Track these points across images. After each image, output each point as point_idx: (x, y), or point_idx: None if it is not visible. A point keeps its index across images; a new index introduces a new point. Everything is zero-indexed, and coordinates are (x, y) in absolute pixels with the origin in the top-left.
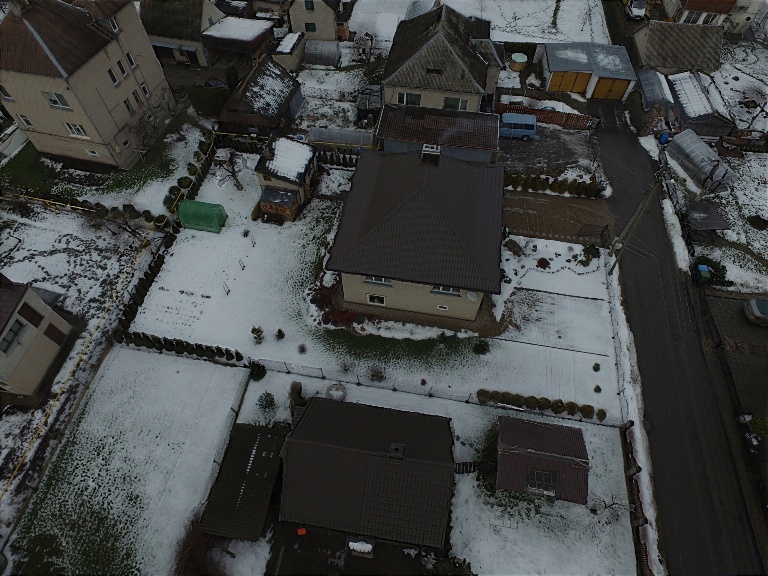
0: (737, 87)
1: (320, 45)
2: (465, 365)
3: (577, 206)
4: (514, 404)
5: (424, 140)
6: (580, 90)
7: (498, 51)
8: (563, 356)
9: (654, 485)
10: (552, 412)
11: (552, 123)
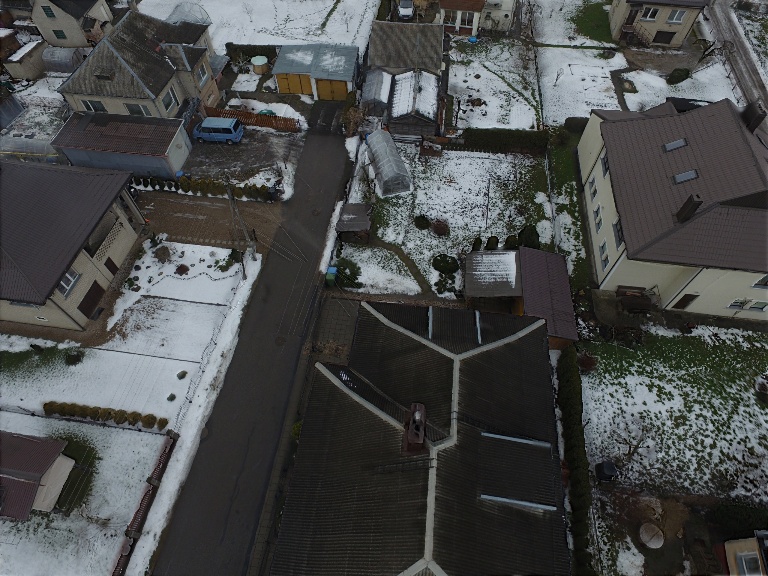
0: (474, 85)
1: (57, 52)
2: (49, 377)
3: (250, 210)
4: (78, 415)
5: (95, 147)
6: (310, 92)
7: (190, 55)
8: (154, 364)
9: (180, 495)
10: (114, 422)
11: (266, 126)
